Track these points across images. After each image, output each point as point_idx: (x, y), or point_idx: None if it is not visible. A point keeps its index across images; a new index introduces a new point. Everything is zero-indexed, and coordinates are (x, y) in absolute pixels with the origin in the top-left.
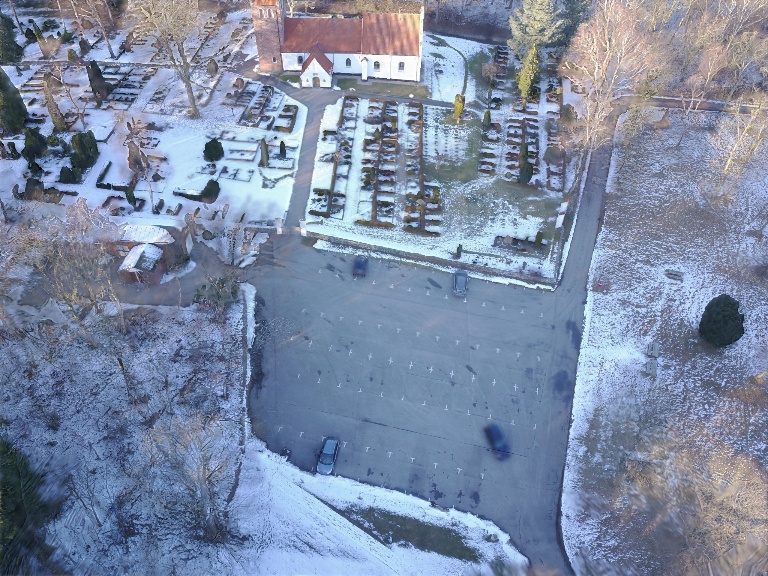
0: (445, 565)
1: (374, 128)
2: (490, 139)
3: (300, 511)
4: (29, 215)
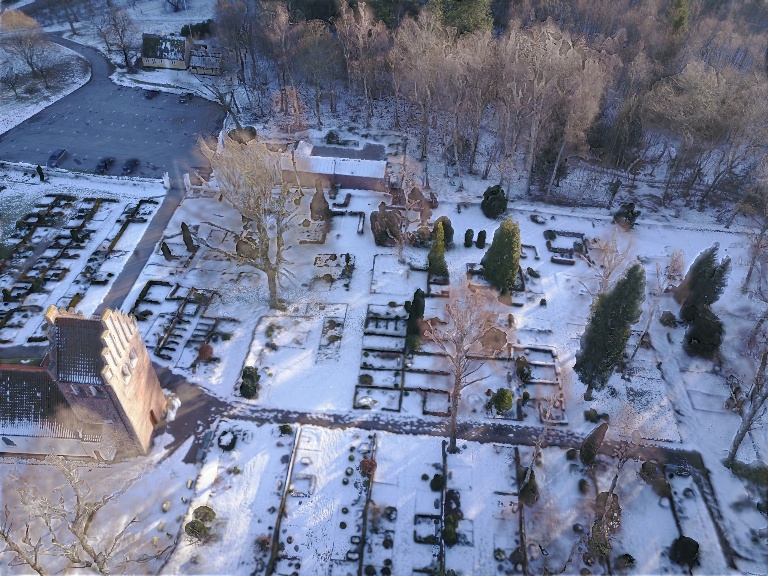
0: None
1: (35, 299)
2: None
3: None
4: None
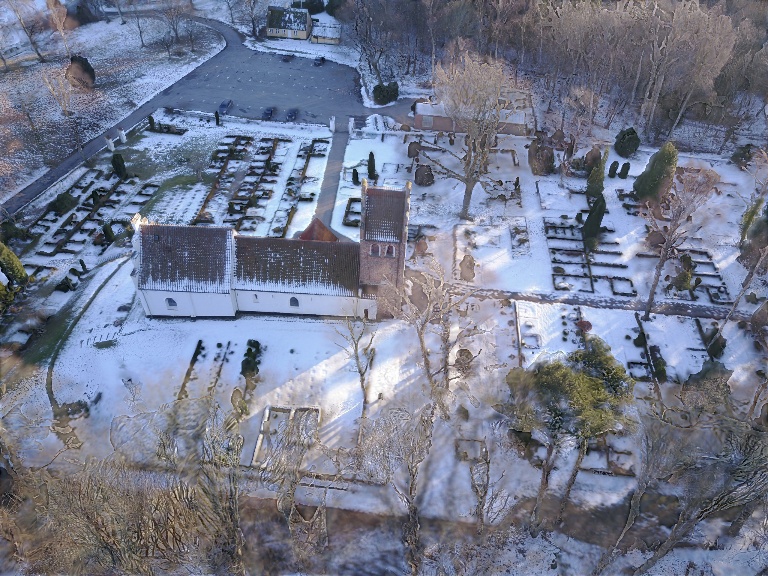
0: None
1: (255, 211)
2: (121, 222)
3: (332, 54)
4: (549, 134)
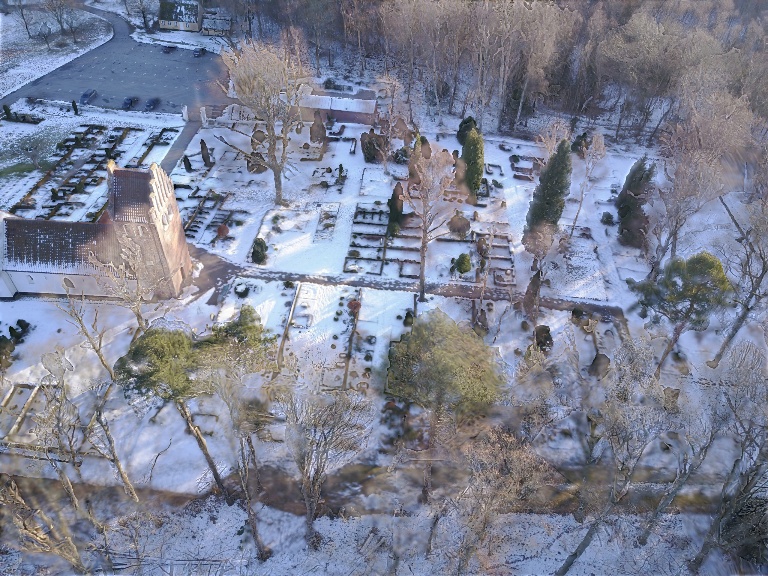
0: (163, 39)
1: (78, 198)
2: None
3: None
4: None
